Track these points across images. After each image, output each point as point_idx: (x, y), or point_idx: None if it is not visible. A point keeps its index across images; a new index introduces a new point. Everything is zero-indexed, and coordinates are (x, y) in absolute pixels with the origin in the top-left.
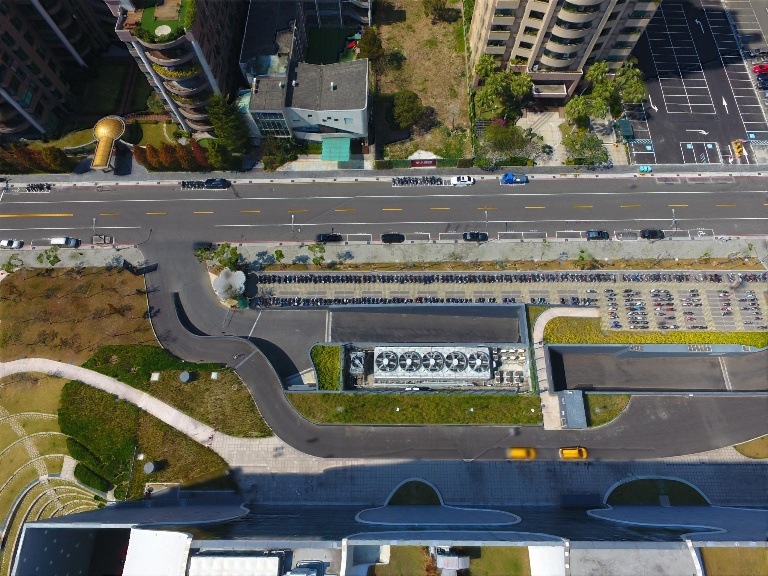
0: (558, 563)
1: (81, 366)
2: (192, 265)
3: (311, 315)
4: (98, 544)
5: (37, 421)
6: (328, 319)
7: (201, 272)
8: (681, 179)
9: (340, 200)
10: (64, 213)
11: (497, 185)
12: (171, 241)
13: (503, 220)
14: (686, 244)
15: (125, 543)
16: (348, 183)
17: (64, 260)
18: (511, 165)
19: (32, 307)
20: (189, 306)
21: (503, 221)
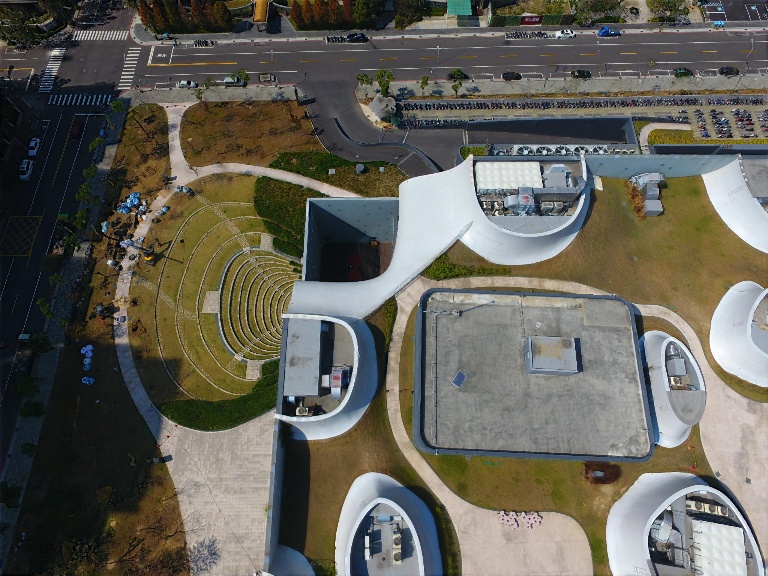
0: (732, 172)
1: (268, 166)
2: (345, 98)
3: (450, 133)
4: (324, 262)
5: (235, 208)
6: (465, 136)
7: (353, 103)
8: (749, 32)
9: (463, 50)
10: (229, 62)
11: (594, 38)
12: (324, 81)
13: (603, 63)
14: (758, 78)
15: (351, 255)
16: (468, 37)
17: (235, 96)
18: (605, 22)
19: (216, 128)
20: (347, 127)
21: (603, 63)
